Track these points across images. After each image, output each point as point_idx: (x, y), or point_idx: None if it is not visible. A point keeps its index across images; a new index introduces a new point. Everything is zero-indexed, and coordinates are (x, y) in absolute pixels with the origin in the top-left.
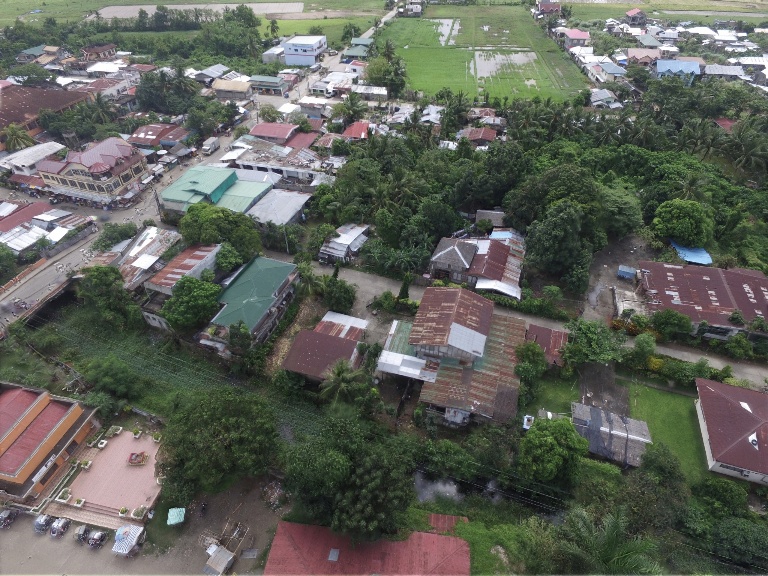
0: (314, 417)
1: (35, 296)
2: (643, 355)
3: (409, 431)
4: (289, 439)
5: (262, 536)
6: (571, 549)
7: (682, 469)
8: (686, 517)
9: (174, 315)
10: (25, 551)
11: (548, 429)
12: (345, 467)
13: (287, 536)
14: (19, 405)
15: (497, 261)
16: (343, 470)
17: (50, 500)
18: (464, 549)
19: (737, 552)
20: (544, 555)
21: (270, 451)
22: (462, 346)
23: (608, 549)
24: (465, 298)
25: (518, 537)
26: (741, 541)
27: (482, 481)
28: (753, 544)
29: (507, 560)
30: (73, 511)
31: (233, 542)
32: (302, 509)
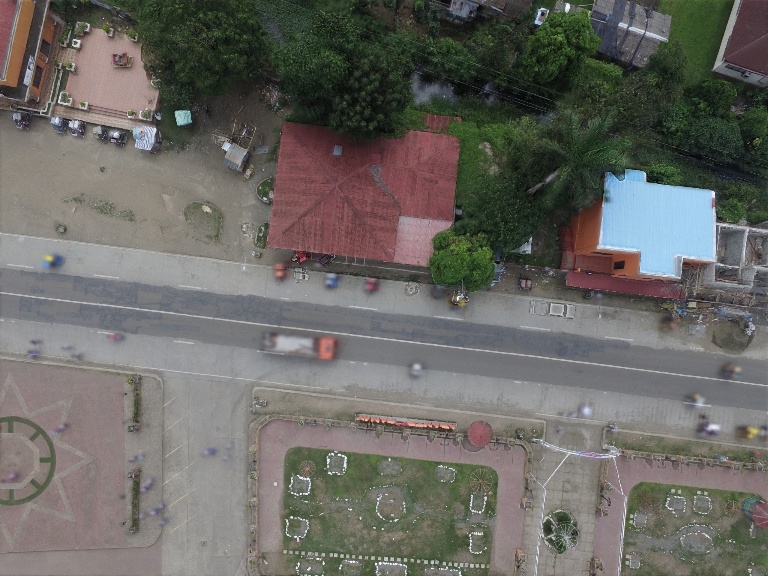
0: (302, 10)
1: None
2: None
3: (409, 28)
4: (278, 38)
5: (269, 135)
6: (552, 145)
7: (685, 70)
8: (667, 116)
9: None
10: (56, 149)
11: (562, 25)
12: (343, 69)
13: (293, 135)
14: None
15: None
16: (341, 72)
17: (53, 103)
18: (455, 145)
19: (697, 146)
20: (526, 149)
21: (261, 52)
22: None
23: (586, 144)
24: None
25: (505, 135)
26: (706, 137)
27: (480, 83)
28: (715, 139)
29: (492, 154)
30: (81, 114)
31: (244, 140)
32: (303, 111)
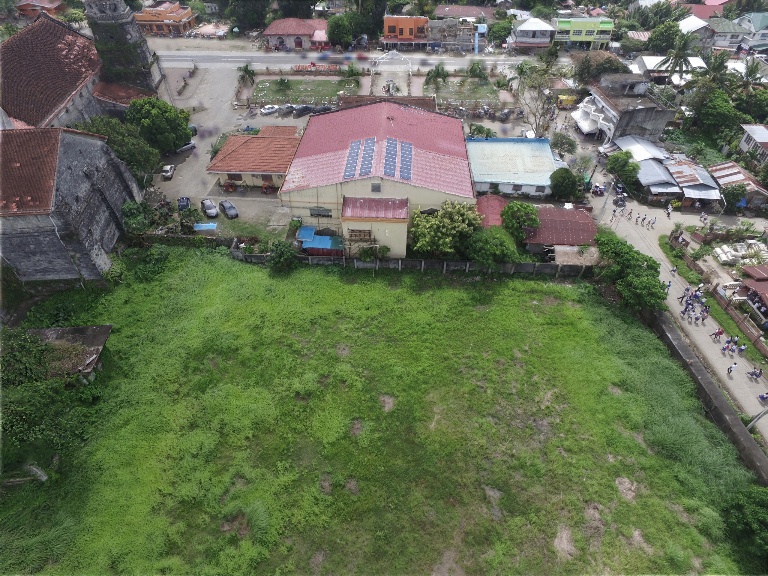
0: None
1: (148, 4)
2: (421, 5)
3: None
4: None
5: None
6: None
7: None
8: None
9: None
10: None
11: None
12: None
13: None
14: (169, 4)
15: None
16: None
17: None
18: None
19: None
20: None
21: None
22: None
23: None
24: None
25: None
26: None
27: None
28: None
29: None
30: None
31: None
32: None
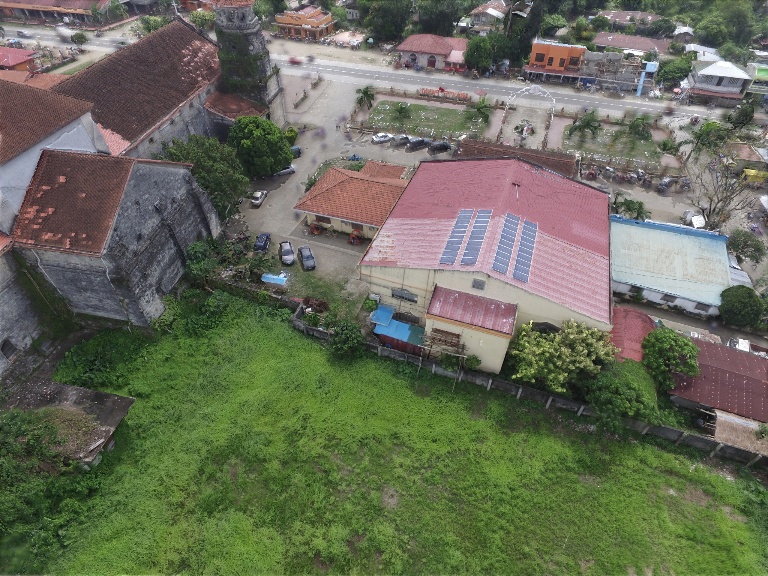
0: None
1: (294, 5)
2: (580, 30)
3: None
4: None
5: None
6: None
7: None
8: None
9: (364, 1)
10: (316, 47)
11: None
12: None
13: None
14: None
15: (521, 7)
16: None
17: None
18: None
19: None
20: None
21: (409, 19)
22: (492, 13)
23: None
24: (499, 5)
25: None
26: None
27: None
28: None
29: None
30: None
31: None
32: None
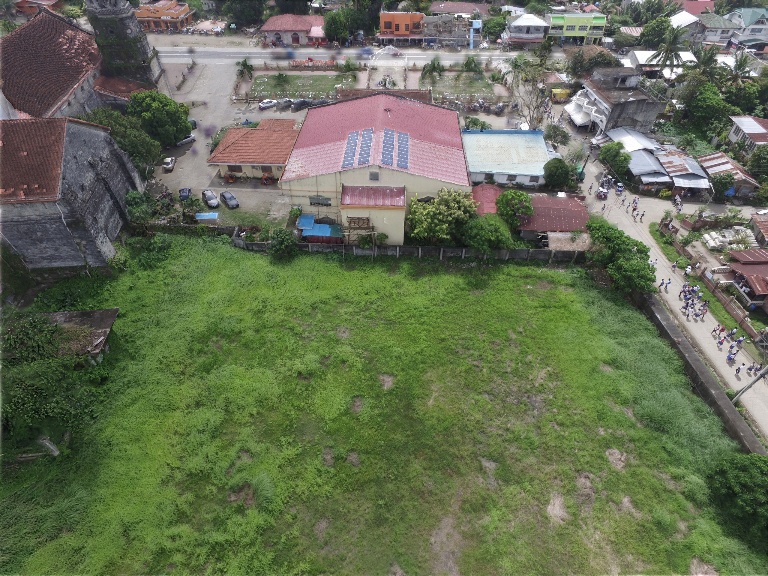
0: None
1: (145, 1)
2: (417, 2)
3: None
4: None
5: None
6: None
7: None
8: None
9: None
10: (181, 37)
11: None
12: None
13: None
14: None
15: None
16: None
17: None
18: None
19: None
20: None
21: (265, 3)
22: None
23: None
24: None
25: None
26: None
27: None
28: None
29: None
30: None
31: None
32: None
